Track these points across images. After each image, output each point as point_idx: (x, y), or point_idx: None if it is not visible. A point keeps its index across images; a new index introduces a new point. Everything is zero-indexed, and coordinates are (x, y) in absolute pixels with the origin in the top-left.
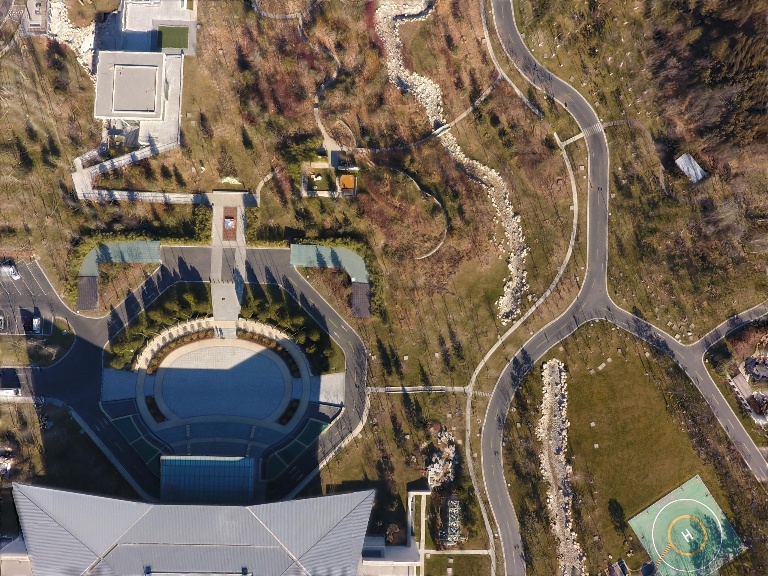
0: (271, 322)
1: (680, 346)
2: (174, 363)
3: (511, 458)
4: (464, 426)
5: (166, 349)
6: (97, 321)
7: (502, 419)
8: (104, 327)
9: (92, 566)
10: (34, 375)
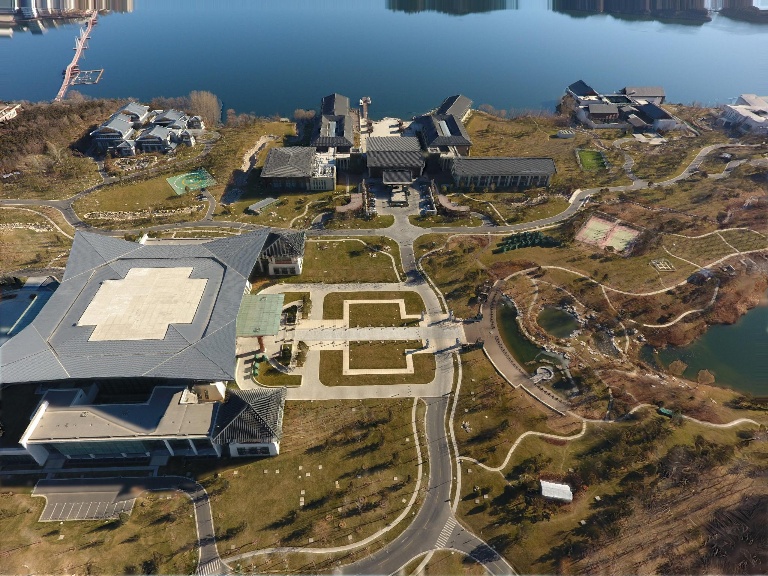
0: None
1: None
2: None
3: None
4: None
5: None
6: None
7: None
8: None
9: None
10: None
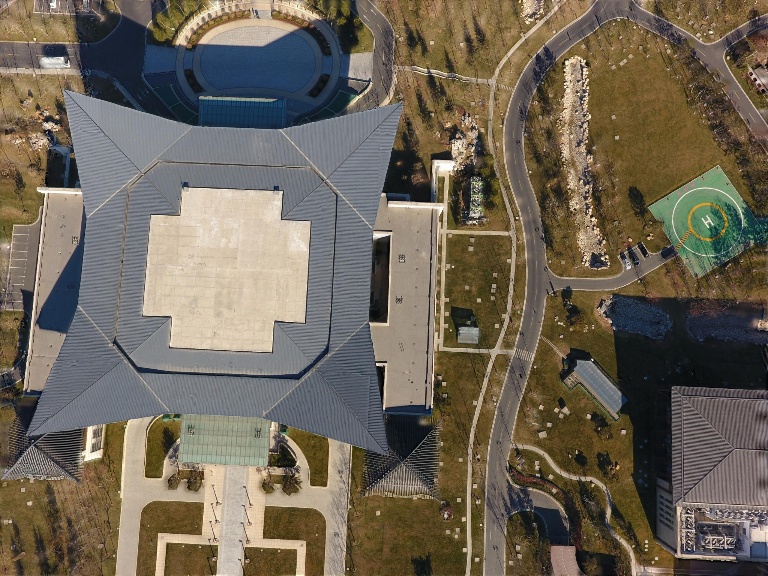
0: (304, 3)
1: (701, 44)
2: (212, 40)
3: (532, 148)
4: (487, 116)
5: (205, 26)
6: (142, 2)
7: (524, 111)
8: (148, 8)
9: (134, 180)
10: (82, 50)
